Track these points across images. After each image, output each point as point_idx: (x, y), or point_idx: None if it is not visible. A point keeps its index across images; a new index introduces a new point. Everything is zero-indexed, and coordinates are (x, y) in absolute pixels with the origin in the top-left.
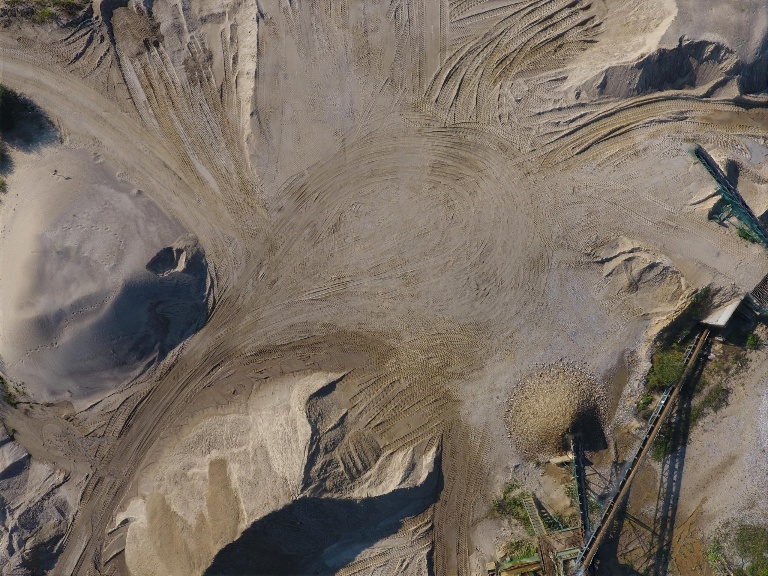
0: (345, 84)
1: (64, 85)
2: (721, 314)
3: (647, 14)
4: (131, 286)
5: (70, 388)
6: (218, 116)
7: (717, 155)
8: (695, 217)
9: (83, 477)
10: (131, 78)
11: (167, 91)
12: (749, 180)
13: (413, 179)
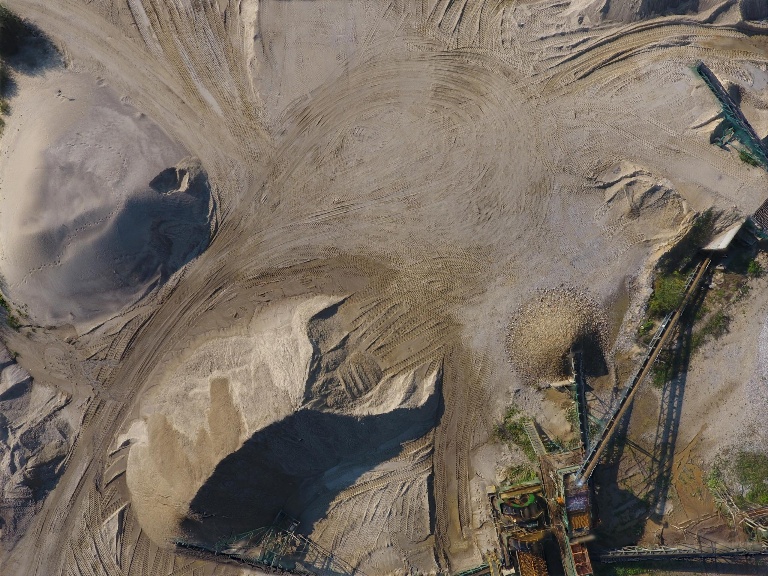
0: (348, 8)
1: (68, 10)
2: (722, 239)
3: None
4: (134, 202)
5: (72, 310)
6: (222, 41)
7: (719, 79)
8: (697, 141)
9: (85, 400)
10: (135, 4)
11: (171, 16)
12: (751, 106)
13: (416, 103)
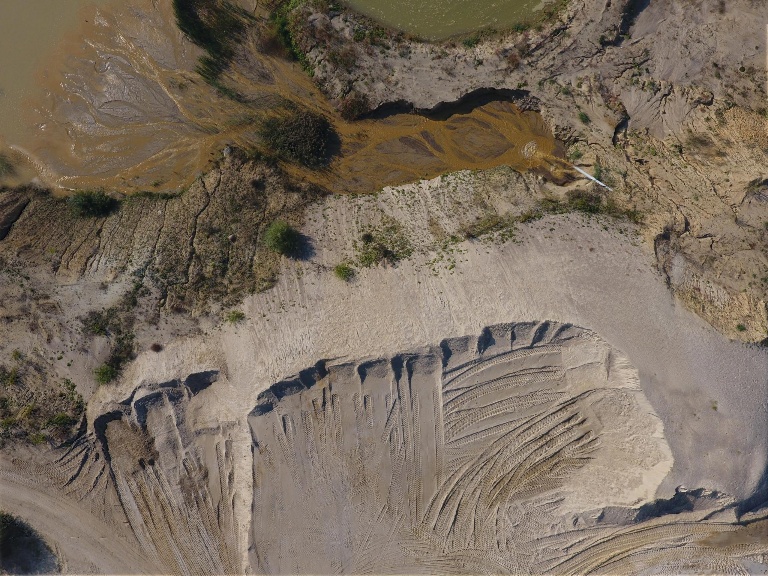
0: (342, 513)
1: (60, 508)
2: None
3: (643, 449)
4: None
5: None
6: (216, 539)
7: None
8: None
9: None
10: (127, 499)
11: (164, 513)
12: None
13: None
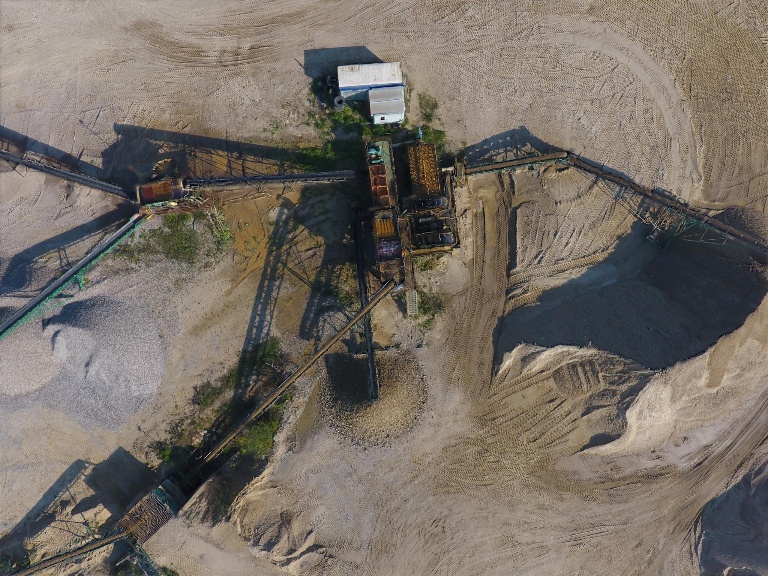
0: None
1: None
2: None
3: None
4: None
5: None
6: None
7: None
8: None
9: None
10: None
11: None
12: None
13: None
